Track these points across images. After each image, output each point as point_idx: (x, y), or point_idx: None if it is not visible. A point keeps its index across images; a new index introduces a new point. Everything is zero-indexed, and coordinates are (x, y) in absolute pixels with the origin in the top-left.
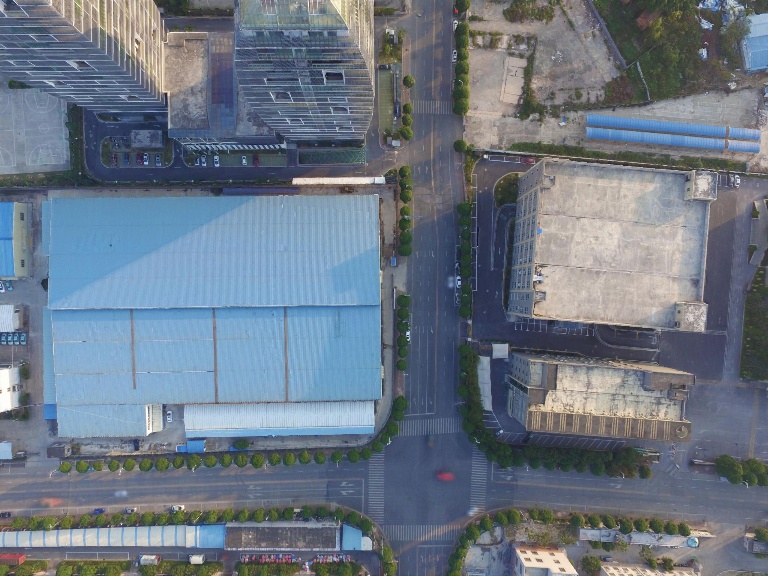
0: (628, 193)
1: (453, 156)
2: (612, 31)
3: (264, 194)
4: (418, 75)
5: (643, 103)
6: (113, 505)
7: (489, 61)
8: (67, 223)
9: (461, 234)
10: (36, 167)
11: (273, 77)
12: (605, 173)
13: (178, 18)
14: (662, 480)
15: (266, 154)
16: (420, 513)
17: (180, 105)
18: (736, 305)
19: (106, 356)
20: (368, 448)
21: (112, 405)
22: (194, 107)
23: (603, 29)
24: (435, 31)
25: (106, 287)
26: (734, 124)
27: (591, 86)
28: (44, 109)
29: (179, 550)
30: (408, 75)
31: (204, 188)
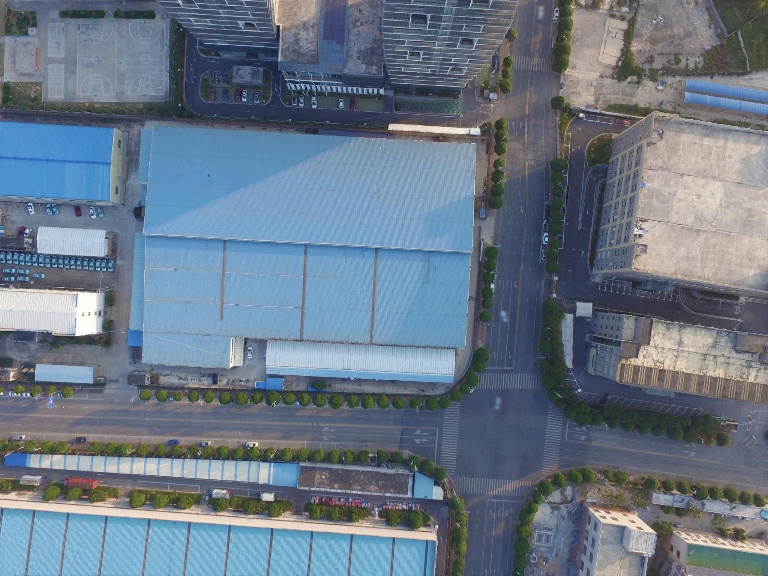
0: (733, 154)
1: (548, 113)
2: None
3: None
4: (518, 31)
5: (742, 72)
6: (187, 437)
7: (590, 21)
8: (167, 151)
9: (553, 190)
10: (135, 97)
11: None
12: (711, 132)
13: None
14: (736, 451)
15: (363, 99)
16: (492, 467)
17: (291, 39)
18: None
19: (196, 285)
20: (447, 397)
21: (198, 335)
22: (305, 42)
23: None
24: None
25: (202, 216)
26: None
27: (690, 52)
28: (147, 40)
29: (250, 487)
30: (511, 28)
31: (299, 128)
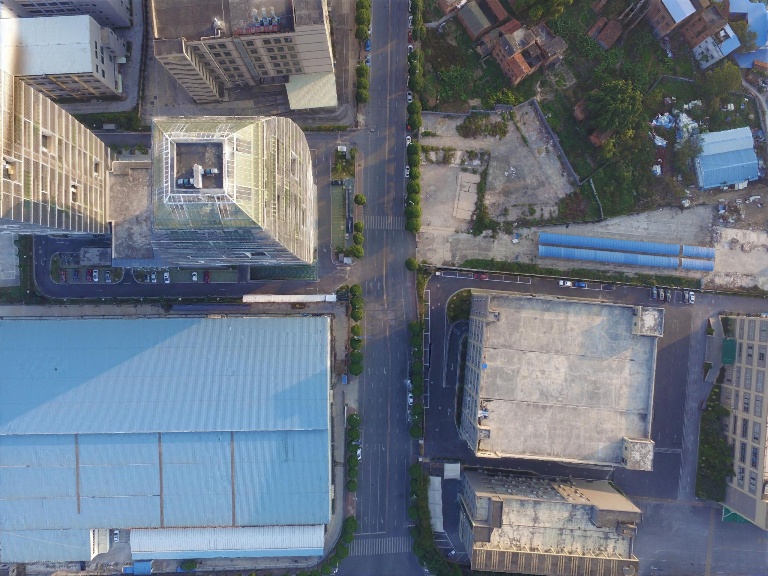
0: (575, 326)
1: (406, 272)
2: (565, 147)
3: (215, 310)
4: (371, 190)
5: (596, 220)
6: None
7: (442, 176)
8: (12, 346)
9: (412, 353)
10: None
11: (196, 255)
12: (552, 306)
13: (130, 133)
14: None
15: (217, 270)
16: None
17: (125, 234)
18: (691, 423)
19: (50, 481)
20: (317, 571)
21: (56, 530)
22: (139, 236)
23: (556, 145)
24: (388, 146)
25: (50, 412)
26: (688, 241)
27: (544, 202)
28: None
29: None
30: (359, 194)
31: (154, 304)
